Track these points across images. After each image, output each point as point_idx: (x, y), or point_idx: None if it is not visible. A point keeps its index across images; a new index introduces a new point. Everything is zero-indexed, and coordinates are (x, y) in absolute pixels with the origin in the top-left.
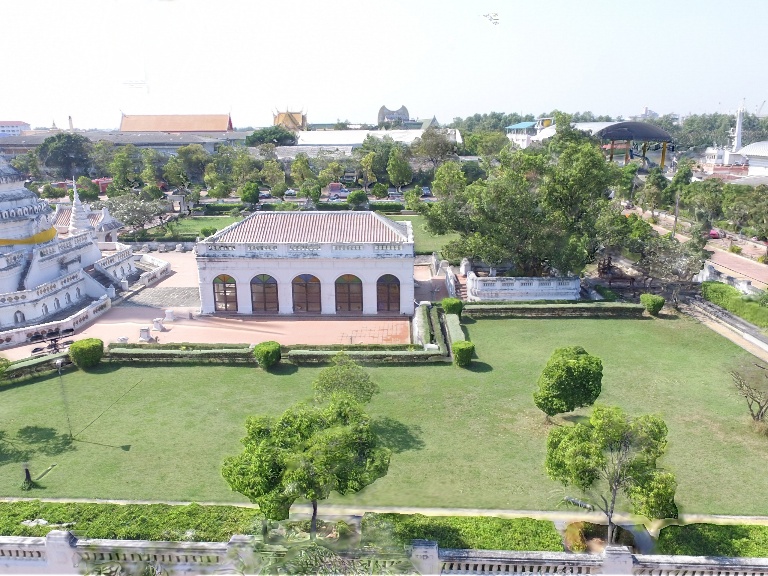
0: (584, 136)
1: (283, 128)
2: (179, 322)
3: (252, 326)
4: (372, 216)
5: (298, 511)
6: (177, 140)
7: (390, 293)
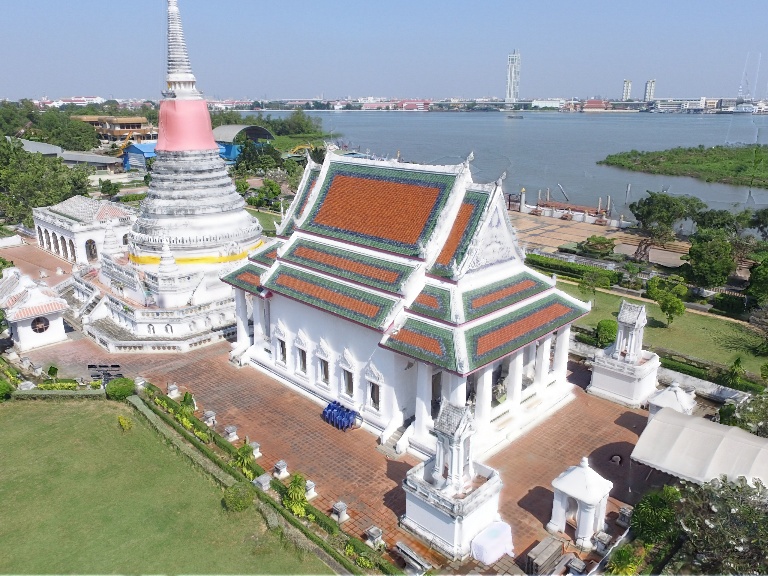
0: None
1: None
2: None
3: None
4: None
5: (263, 211)
6: None
7: None
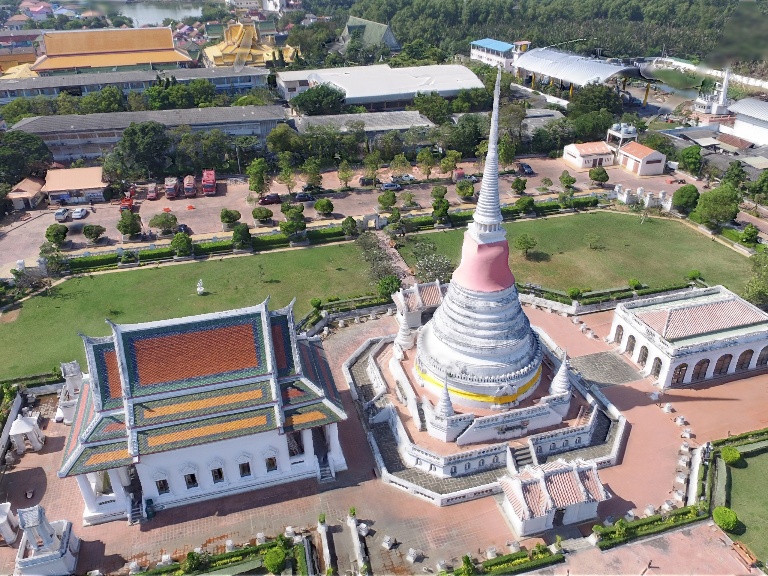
0: (610, 92)
1: (333, 87)
2: (664, 399)
3: (710, 395)
4: (737, 301)
5: None
6: (252, 117)
7: (765, 355)
